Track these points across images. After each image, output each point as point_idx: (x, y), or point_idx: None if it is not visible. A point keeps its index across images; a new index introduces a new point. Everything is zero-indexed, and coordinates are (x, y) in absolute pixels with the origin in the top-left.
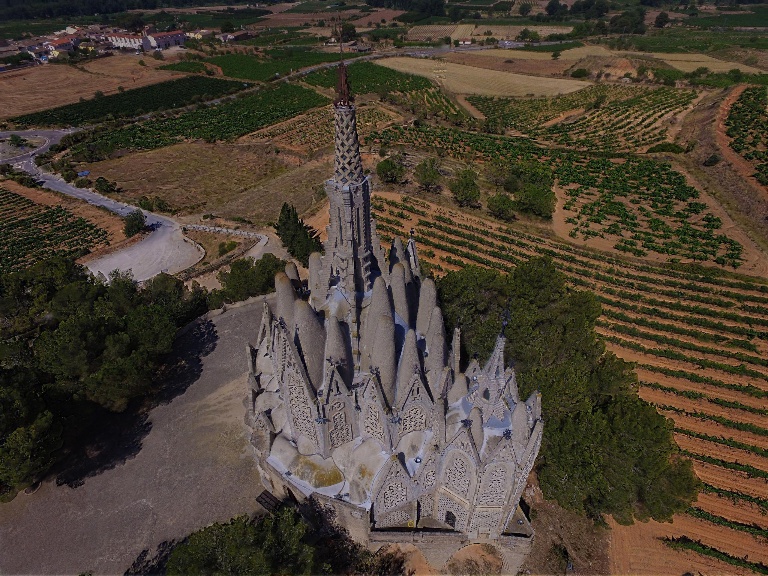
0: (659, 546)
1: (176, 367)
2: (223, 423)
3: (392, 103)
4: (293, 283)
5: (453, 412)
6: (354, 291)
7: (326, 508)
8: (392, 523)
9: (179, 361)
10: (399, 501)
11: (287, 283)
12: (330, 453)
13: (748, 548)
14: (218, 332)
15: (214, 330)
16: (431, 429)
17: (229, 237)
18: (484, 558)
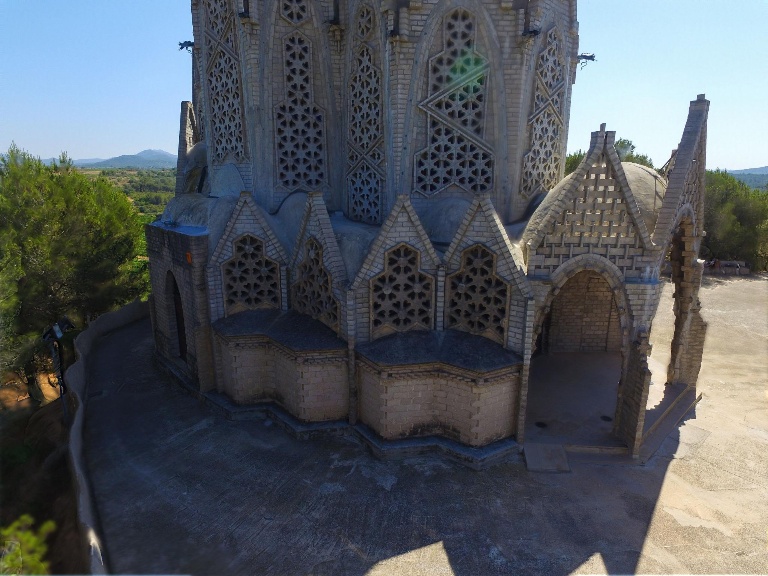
0: None
1: None
2: None
3: None
4: None
5: None
6: None
7: None
8: None
9: None
10: None
11: None
12: None
13: None
14: None
15: None
16: None
17: None
18: None
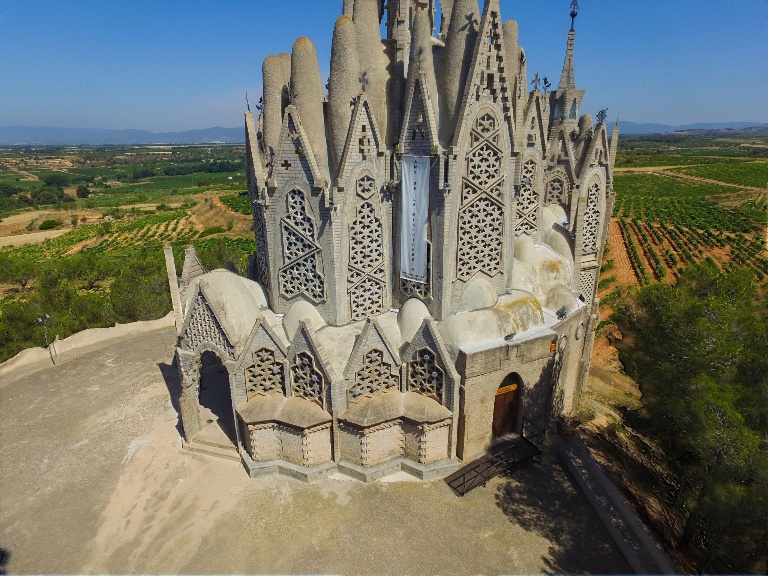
0: None
1: None
2: (221, 520)
3: None
4: (286, 94)
5: None
6: None
7: (559, 352)
8: None
9: None
10: None
11: None
12: None
13: None
14: None
15: None
16: None
17: None
18: None
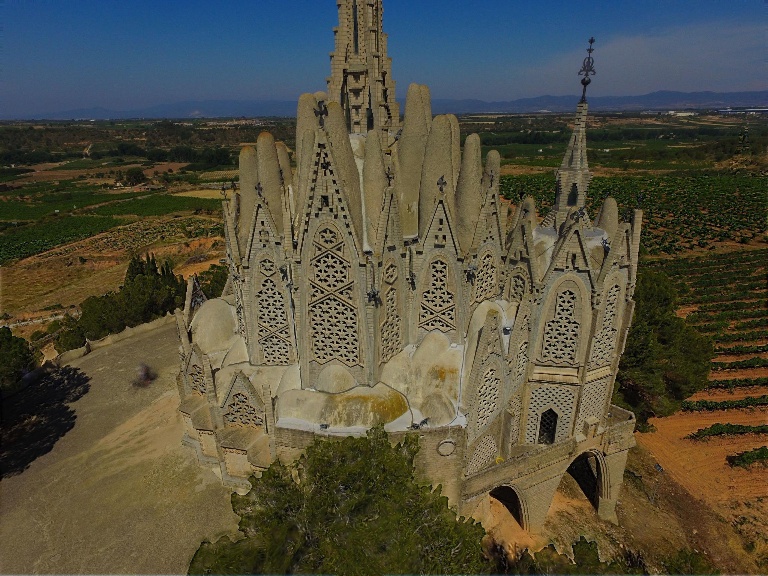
0: (690, 444)
1: (22, 426)
2: (144, 461)
3: (209, 214)
4: None
5: (535, 243)
6: (384, 107)
7: None
8: (479, 466)
9: (25, 418)
10: (490, 412)
11: (271, 139)
12: (378, 375)
13: (746, 420)
14: (87, 373)
15: (78, 373)
16: (500, 297)
17: (46, 323)
18: (571, 505)
